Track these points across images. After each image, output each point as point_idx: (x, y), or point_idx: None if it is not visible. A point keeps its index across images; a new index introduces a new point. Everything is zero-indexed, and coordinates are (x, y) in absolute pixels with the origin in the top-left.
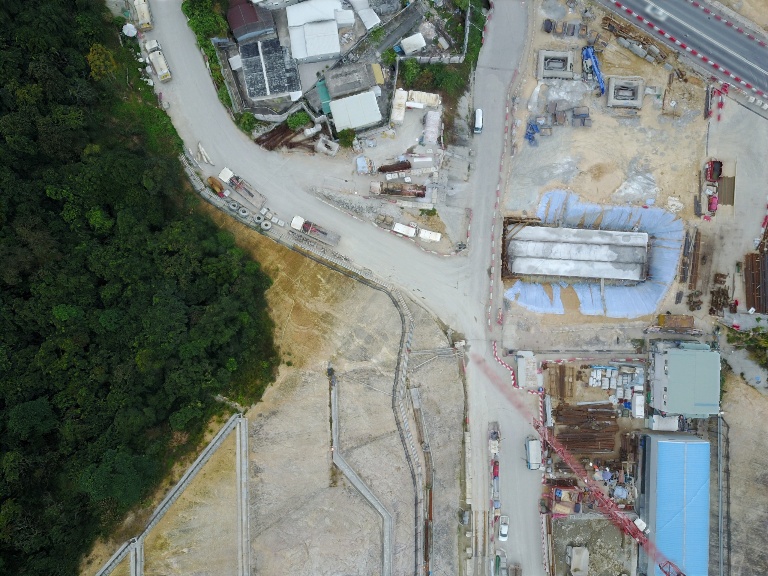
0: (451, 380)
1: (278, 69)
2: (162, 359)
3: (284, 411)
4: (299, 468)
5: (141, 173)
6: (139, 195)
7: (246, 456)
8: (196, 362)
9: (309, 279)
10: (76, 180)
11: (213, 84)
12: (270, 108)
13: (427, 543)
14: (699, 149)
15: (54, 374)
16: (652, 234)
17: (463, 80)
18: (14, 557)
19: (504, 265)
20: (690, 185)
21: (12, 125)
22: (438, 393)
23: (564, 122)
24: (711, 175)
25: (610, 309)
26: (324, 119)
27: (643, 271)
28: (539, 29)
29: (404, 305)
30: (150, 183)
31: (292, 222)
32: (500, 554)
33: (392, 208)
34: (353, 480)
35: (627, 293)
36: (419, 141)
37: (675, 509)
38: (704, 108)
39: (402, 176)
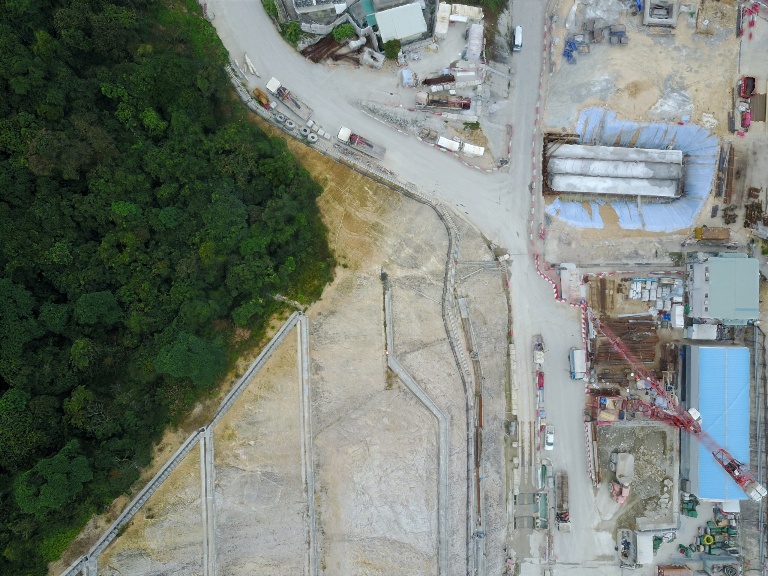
0: (496, 293)
1: None
2: (224, 254)
3: (341, 312)
4: (356, 369)
5: (194, 75)
6: (193, 97)
7: (307, 353)
8: (258, 257)
9: (357, 190)
10: (131, 79)
11: None
12: (314, 21)
13: (477, 450)
14: (732, 67)
15: (116, 268)
16: (686, 152)
17: None
18: (86, 442)
19: (545, 181)
20: (724, 102)
21: (69, 18)
22: (484, 305)
23: (602, 39)
24: (745, 91)
25: (648, 223)
26: (369, 32)
27: (679, 187)
28: None
29: (449, 218)
30: (205, 83)
31: (339, 133)
32: (546, 463)
33: (436, 122)
34: (408, 383)
35: (663, 209)
36: (462, 55)
37: (717, 412)
38: (736, 27)
39: (447, 88)
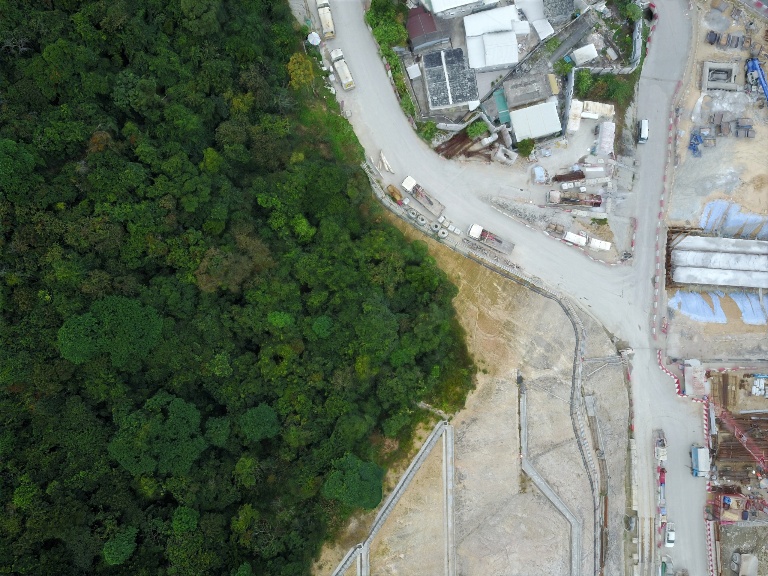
0: (618, 388)
1: (461, 79)
2: (376, 367)
3: (482, 418)
4: (494, 475)
5: (343, 182)
6: (341, 203)
7: (452, 463)
8: (408, 370)
9: (487, 287)
10: (284, 188)
11: (394, 93)
12: (446, 117)
13: (602, 549)
14: None
15: (275, 381)
16: None
17: (631, 91)
18: (254, 562)
19: (668, 274)
20: None
21: (232, 134)
22: (608, 401)
23: (729, 133)
24: None
25: None
26: (501, 128)
27: None
28: (702, 41)
29: (574, 313)
30: (356, 192)
31: (471, 230)
32: (666, 560)
33: (564, 217)
34: (541, 487)
35: None
36: (591, 151)
37: None
38: None
39: (578, 186)
